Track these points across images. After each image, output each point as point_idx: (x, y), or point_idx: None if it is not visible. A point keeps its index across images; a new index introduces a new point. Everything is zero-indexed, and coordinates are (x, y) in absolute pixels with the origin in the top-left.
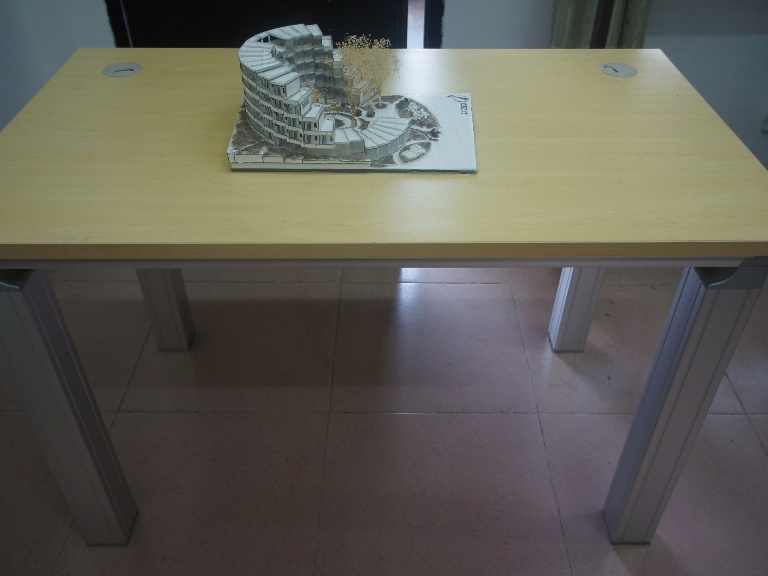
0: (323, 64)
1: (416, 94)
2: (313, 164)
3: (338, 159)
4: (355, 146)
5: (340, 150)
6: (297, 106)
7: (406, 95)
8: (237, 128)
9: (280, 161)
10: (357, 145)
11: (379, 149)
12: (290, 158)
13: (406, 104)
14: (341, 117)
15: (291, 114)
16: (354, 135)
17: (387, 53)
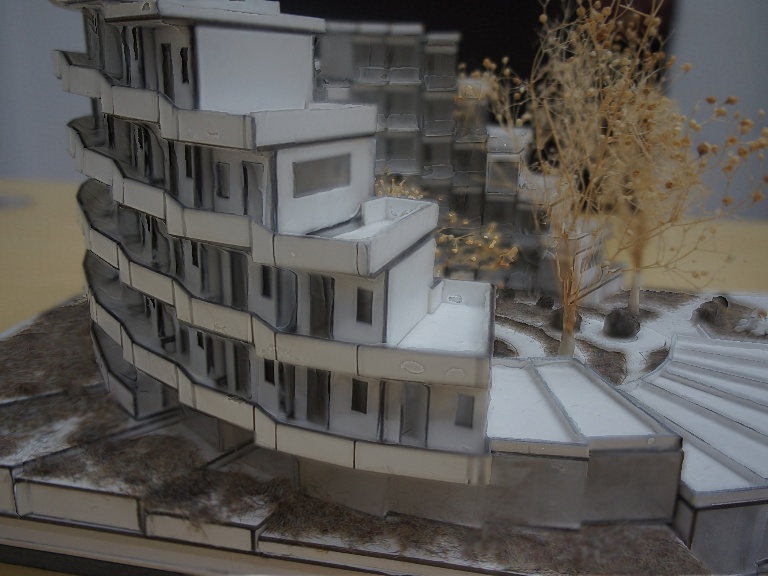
0: (451, 149)
1: (734, 296)
2: (323, 568)
3: (497, 557)
4: (617, 475)
5: (514, 492)
6: (256, 168)
7: (707, 294)
8: (37, 320)
9: (119, 520)
10: (631, 470)
11: (767, 509)
12: (178, 510)
13: (725, 316)
14: (500, 329)
15: (204, 213)
16: (599, 403)
17: (666, 146)
